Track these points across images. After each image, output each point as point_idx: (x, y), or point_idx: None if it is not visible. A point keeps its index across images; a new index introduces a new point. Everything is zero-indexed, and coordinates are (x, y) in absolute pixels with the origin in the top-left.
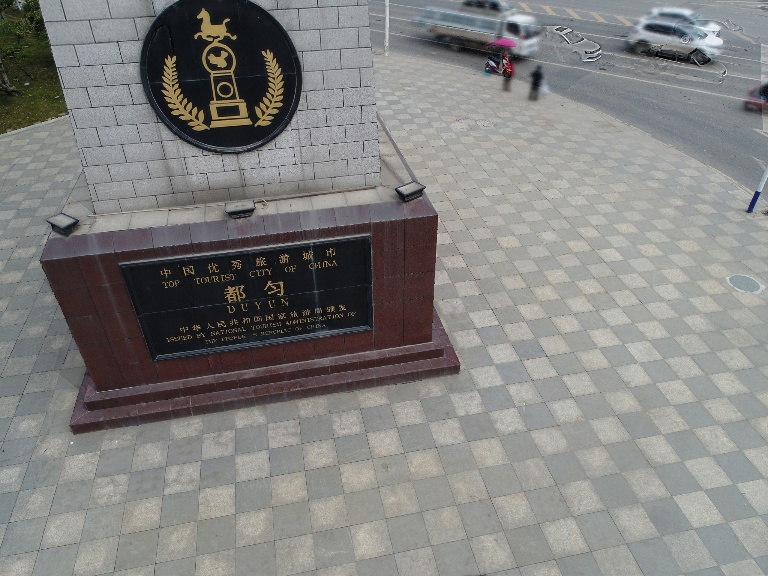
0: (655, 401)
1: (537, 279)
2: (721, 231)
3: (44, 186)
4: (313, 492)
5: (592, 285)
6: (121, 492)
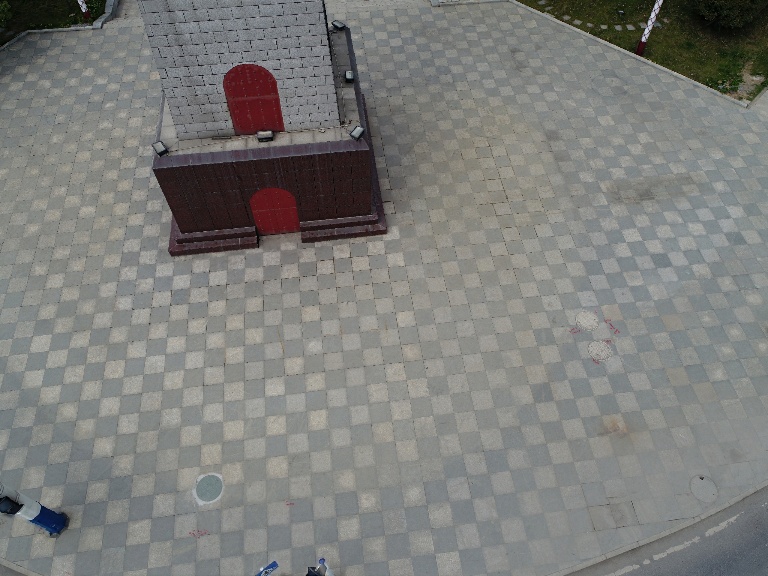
0: (112, 353)
1: (253, 321)
2: (299, 518)
3: (437, 48)
4: (119, 193)
5: (236, 357)
6: (146, 134)
